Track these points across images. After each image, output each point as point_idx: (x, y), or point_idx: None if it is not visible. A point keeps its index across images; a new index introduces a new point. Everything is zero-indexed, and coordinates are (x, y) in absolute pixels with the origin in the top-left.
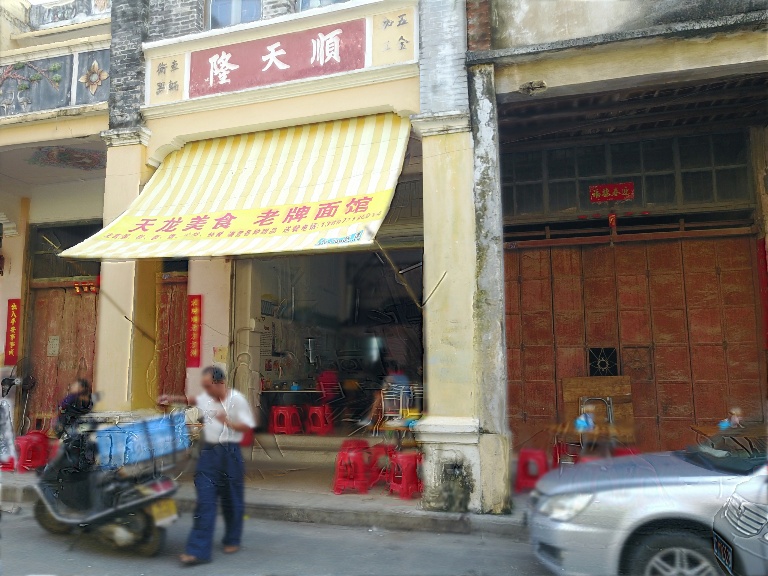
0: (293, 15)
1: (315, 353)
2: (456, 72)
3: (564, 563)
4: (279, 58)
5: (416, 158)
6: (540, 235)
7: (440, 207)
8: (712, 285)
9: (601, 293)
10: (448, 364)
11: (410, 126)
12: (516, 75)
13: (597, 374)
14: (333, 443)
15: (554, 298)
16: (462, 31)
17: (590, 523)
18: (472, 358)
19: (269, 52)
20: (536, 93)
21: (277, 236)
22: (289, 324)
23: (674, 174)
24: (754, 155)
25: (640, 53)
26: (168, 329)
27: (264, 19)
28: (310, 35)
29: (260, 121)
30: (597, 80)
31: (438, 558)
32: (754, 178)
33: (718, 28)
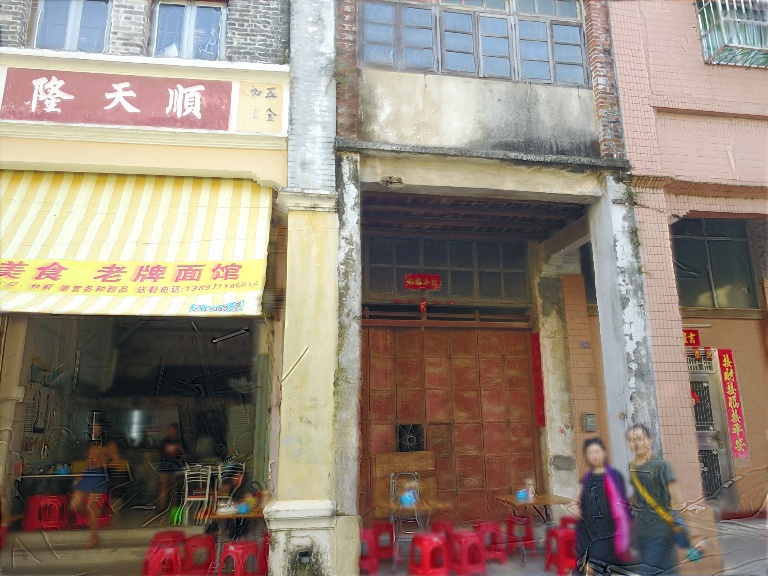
0: (150, 59)
1: (100, 429)
2: (325, 154)
3: None
4: (127, 99)
5: (282, 230)
6: None
7: (304, 282)
8: (499, 370)
9: (411, 373)
10: (306, 444)
11: (271, 197)
12: (378, 168)
13: (406, 450)
14: (123, 537)
15: (371, 376)
16: (331, 117)
17: None
18: (331, 437)
19: (115, 90)
20: (393, 187)
21: (132, 296)
22: (68, 394)
23: (473, 272)
24: (531, 264)
25: (480, 170)
26: None
27: (111, 54)
28: (167, 84)
29: (96, 162)
30: (446, 186)
31: None
32: (531, 283)
33: (538, 163)
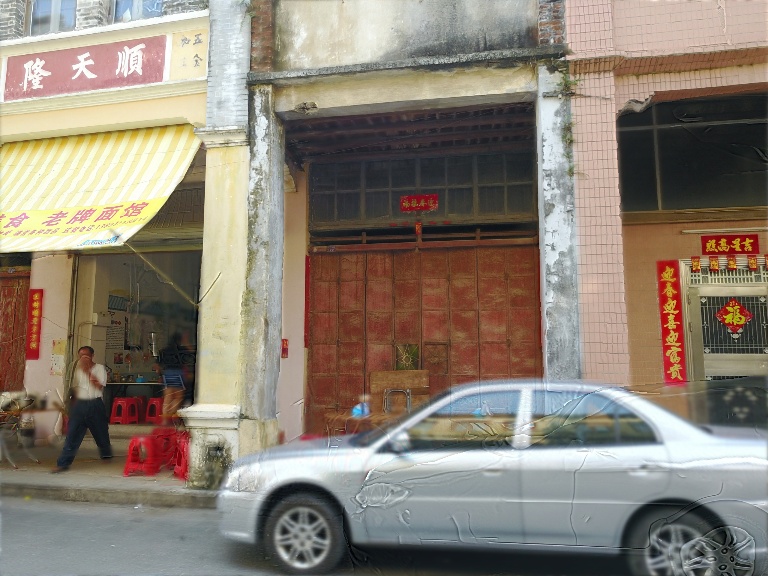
0: (100, 28)
1: (157, 347)
2: (238, 90)
3: (275, 530)
4: (88, 68)
5: (200, 168)
6: (357, 240)
7: (218, 213)
8: (501, 289)
9: (408, 294)
10: (217, 356)
11: None
12: (293, 96)
13: (401, 368)
14: (162, 432)
15: (367, 298)
16: (246, 53)
17: (327, 498)
18: (238, 351)
19: (79, 61)
20: (311, 113)
21: (55, 236)
22: (135, 319)
23: (472, 188)
24: None
25: (396, 82)
26: (13, 322)
27: (76, 30)
28: (117, 48)
29: (69, 126)
30: (360, 104)
31: (169, 528)
32: None
33: (454, 64)
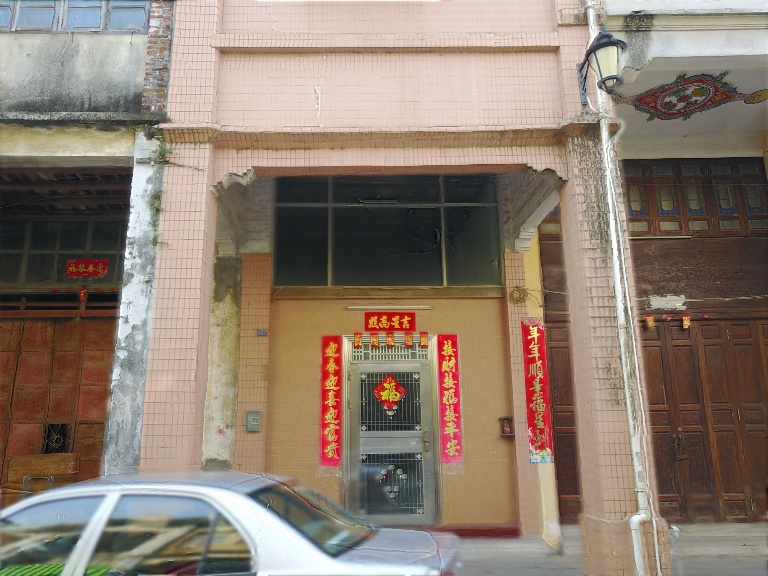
0: None
1: None
2: None
3: None
4: None
5: None
6: (14, 306)
7: None
8: None
9: (68, 367)
10: None
11: None
12: None
13: (50, 451)
14: None
15: (19, 371)
16: None
17: None
18: None
19: None
20: None
21: None
22: None
23: None
24: None
25: None
26: None
27: None
28: None
29: None
30: None
31: None
32: None
33: (46, 121)
